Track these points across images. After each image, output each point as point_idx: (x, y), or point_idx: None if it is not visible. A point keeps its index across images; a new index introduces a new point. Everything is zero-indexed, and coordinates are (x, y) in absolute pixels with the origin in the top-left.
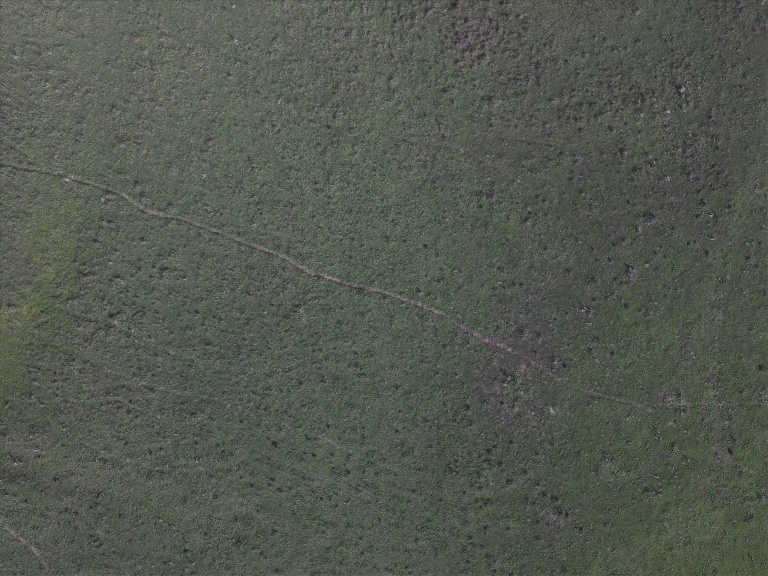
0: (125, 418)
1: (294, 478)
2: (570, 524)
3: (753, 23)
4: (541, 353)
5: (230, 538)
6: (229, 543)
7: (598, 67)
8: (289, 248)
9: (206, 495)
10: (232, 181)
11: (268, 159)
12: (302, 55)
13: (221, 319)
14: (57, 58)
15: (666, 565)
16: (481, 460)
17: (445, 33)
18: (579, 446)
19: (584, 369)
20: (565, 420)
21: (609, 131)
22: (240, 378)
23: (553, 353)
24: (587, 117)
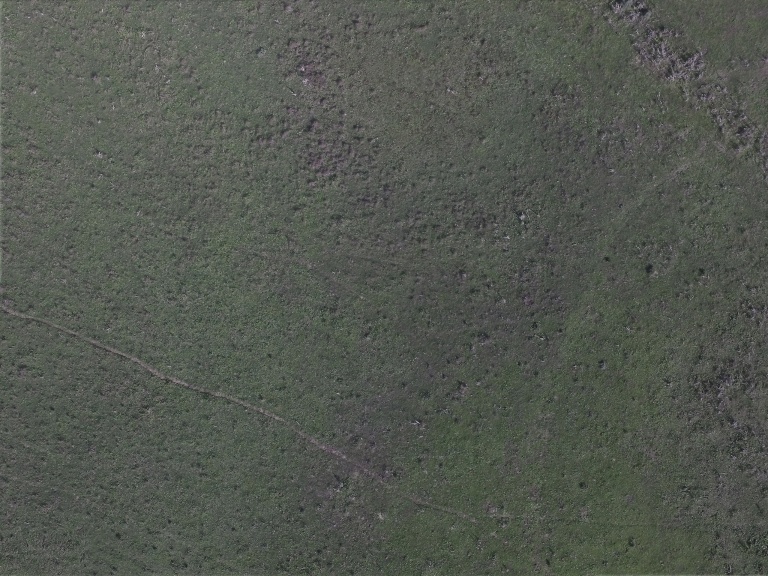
0: None
1: (135, 569)
2: None
3: (593, 156)
4: (374, 462)
5: None
6: None
7: (444, 191)
8: (141, 352)
9: None
10: (91, 286)
11: (125, 267)
12: (162, 170)
13: (74, 416)
14: None
15: None
16: (311, 560)
17: (300, 153)
18: (405, 552)
19: (413, 479)
20: (393, 526)
21: (451, 253)
22: (89, 472)
23: (385, 462)
24: (431, 239)
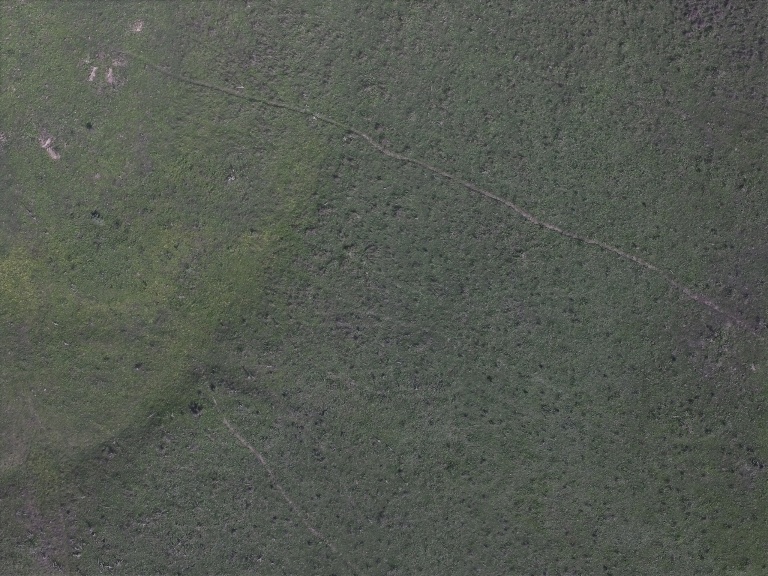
0: (352, 343)
1: (505, 412)
2: (763, 476)
3: None
4: (747, 313)
5: (442, 463)
6: (441, 467)
7: None
8: (515, 196)
9: (422, 421)
10: (466, 130)
11: (501, 111)
12: (540, 16)
13: (447, 258)
14: (312, 3)
15: None
16: (683, 409)
17: (675, 4)
18: None
19: None
20: (765, 378)
21: None
22: (461, 315)
23: (758, 314)
24: None
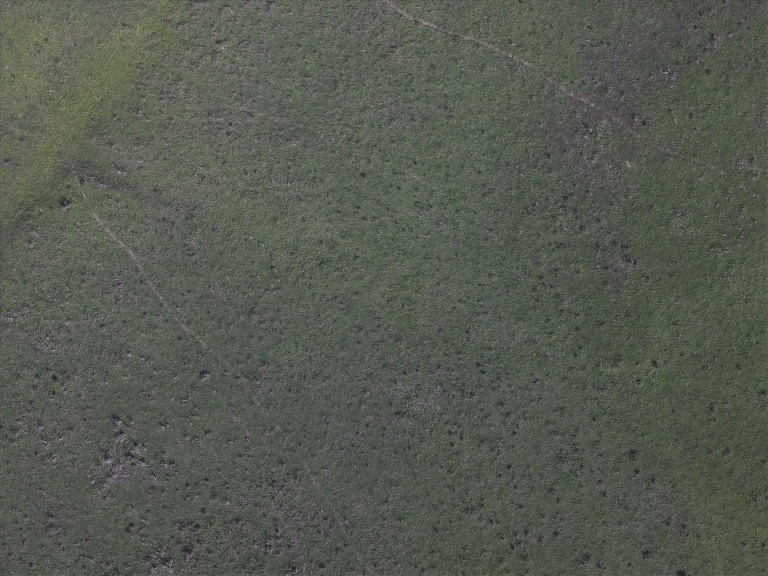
0: (224, 139)
1: (379, 209)
2: (637, 273)
3: None
4: (622, 110)
5: (315, 259)
6: (313, 264)
7: None
8: None
9: (295, 218)
10: None
11: None
12: None
13: (321, 54)
14: None
15: (726, 320)
16: (557, 206)
17: None
18: (652, 200)
19: (662, 129)
20: (640, 175)
21: None
22: (335, 111)
23: (634, 111)
24: None
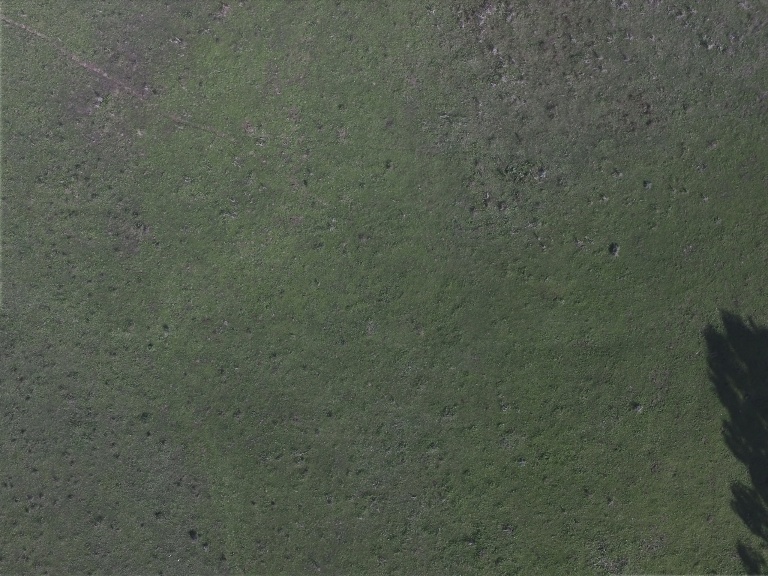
0: None
1: None
2: (148, 239)
3: None
4: (134, 79)
5: None
6: None
7: None
8: None
9: None
10: None
11: None
12: None
13: None
14: None
15: (236, 284)
16: (69, 174)
17: None
18: (162, 168)
19: (174, 97)
20: (152, 143)
21: None
22: None
23: (146, 80)
24: None
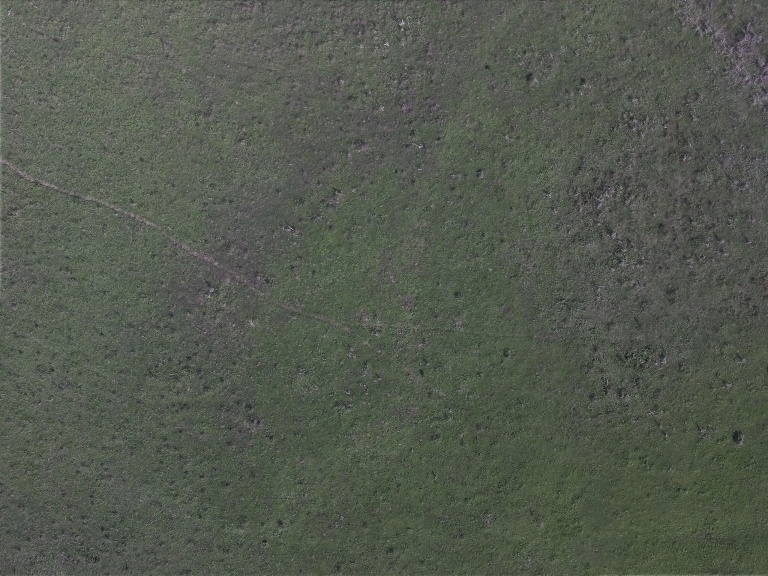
0: None
1: (1, 373)
2: (262, 433)
3: None
4: (246, 268)
5: None
6: None
7: None
8: (10, 154)
9: None
10: None
11: None
12: None
13: None
14: None
15: (352, 477)
16: (181, 367)
17: None
18: (276, 359)
19: (286, 286)
20: (264, 334)
21: (329, 60)
22: None
23: (257, 269)
24: (309, 45)
